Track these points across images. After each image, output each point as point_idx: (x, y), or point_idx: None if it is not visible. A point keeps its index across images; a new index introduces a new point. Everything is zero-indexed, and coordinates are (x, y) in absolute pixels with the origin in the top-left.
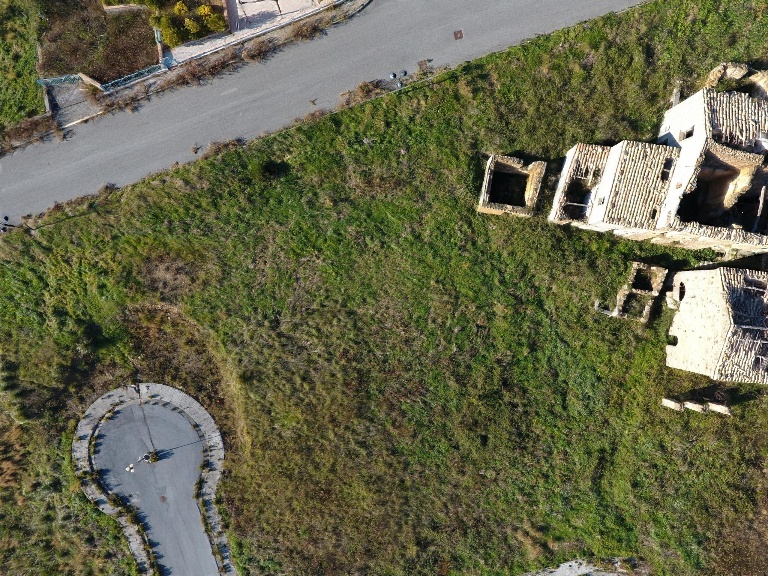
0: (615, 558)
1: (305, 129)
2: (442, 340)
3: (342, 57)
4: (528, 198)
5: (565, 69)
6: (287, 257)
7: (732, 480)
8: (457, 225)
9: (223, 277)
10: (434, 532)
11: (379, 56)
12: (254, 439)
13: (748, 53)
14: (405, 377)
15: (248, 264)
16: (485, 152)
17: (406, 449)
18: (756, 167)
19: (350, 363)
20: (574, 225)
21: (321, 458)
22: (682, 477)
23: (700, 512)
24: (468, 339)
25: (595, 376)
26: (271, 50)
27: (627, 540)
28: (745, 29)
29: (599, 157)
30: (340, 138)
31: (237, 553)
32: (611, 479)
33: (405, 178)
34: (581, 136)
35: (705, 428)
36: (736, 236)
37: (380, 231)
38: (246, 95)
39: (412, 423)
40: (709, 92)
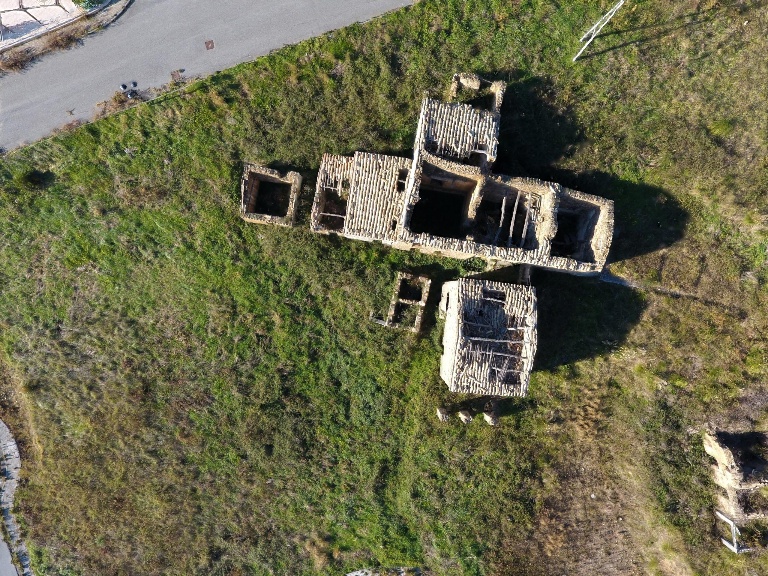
0: (401, 568)
1: (62, 139)
2: (223, 349)
3: (98, 67)
4: (288, 208)
5: (315, 79)
6: (63, 267)
7: (508, 490)
8: (226, 235)
9: (1, 286)
10: (225, 541)
11: (133, 66)
12: (45, 448)
13: (491, 63)
14: (190, 386)
15: (24, 274)
16: (249, 162)
17: (196, 458)
18: (485, 178)
19: (135, 372)
20: (339, 235)
21: (113, 467)
22: (461, 487)
23: (478, 522)
24: (250, 348)
25: (375, 386)
26: (29, 60)
27: (411, 550)
28: (488, 39)
29: (345, 168)
30: (101, 148)
31: (36, 562)
32: (395, 489)
33: (171, 188)
34: (335, 146)
35: (481, 438)
36: (467, 247)
37: (152, 241)
38: (6, 105)
39: (200, 432)
40: (430, 103)
